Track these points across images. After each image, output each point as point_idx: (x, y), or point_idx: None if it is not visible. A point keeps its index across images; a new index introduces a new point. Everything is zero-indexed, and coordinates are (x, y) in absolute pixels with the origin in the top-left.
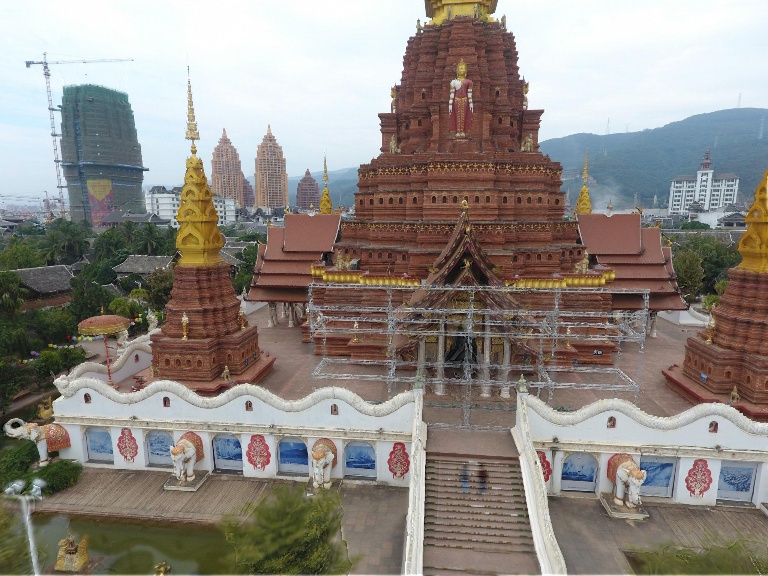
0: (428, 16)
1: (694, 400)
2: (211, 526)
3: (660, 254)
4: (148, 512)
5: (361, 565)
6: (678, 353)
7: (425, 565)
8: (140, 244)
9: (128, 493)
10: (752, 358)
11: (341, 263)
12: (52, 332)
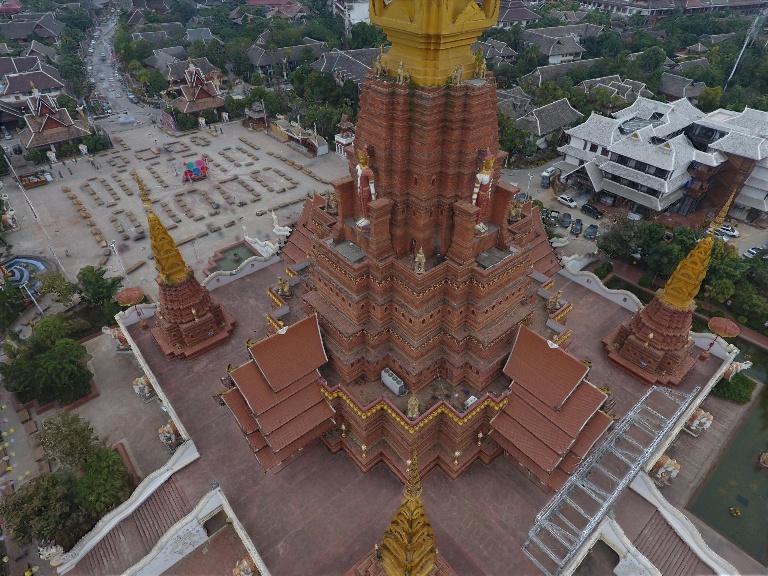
0: None
1: (642, 380)
2: None
3: (543, 230)
4: None
5: None
6: None
7: None
8: None
9: None
10: (674, 355)
11: None
12: None
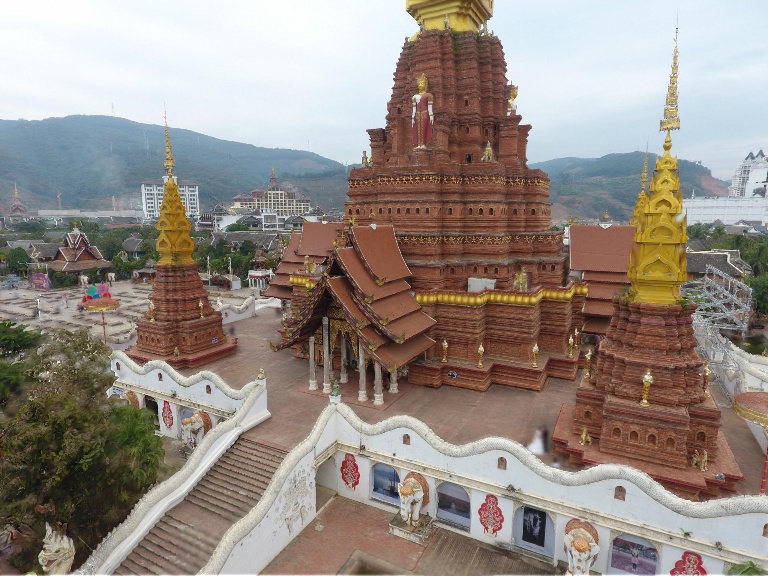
0: (414, 6)
1: None
2: None
3: None
4: None
5: None
6: None
7: None
8: None
9: None
10: None
11: None
12: None
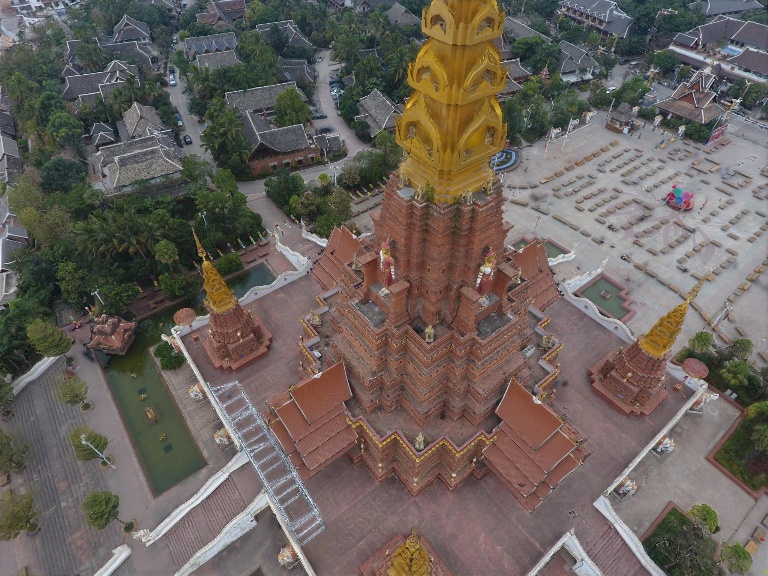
0: None
1: None
2: (188, 428)
3: (553, 463)
4: (181, 404)
5: (197, 487)
6: (486, 527)
7: (191, 511)
8: (392, 70)
9: (185, 388)
10: None
11: (312, 318)
12: (239, 233)
